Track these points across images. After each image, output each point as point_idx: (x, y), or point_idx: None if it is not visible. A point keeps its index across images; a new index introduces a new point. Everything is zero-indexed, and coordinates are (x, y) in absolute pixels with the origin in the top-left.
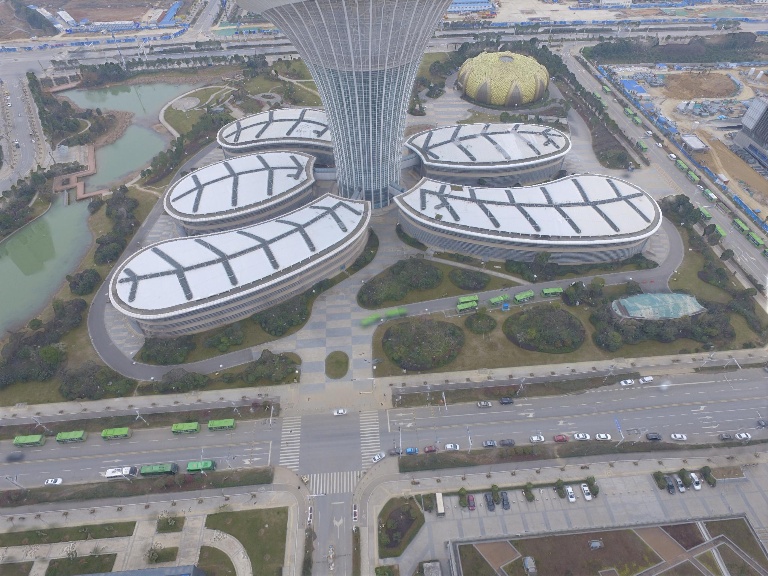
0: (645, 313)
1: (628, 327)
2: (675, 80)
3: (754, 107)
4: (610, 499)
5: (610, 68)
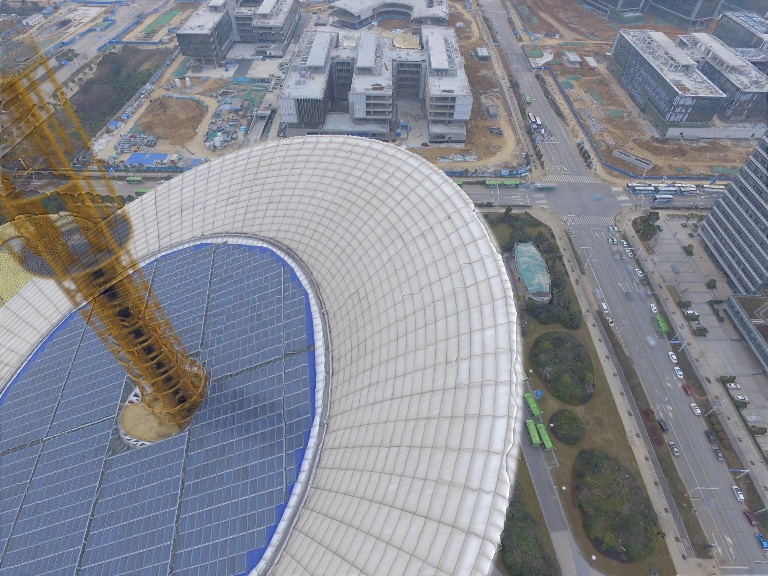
0: (544, 281)
1: (568, 298)
2: (155, 127)
3: (284, 106)
4: (730, 371)
5: (84, 160)
